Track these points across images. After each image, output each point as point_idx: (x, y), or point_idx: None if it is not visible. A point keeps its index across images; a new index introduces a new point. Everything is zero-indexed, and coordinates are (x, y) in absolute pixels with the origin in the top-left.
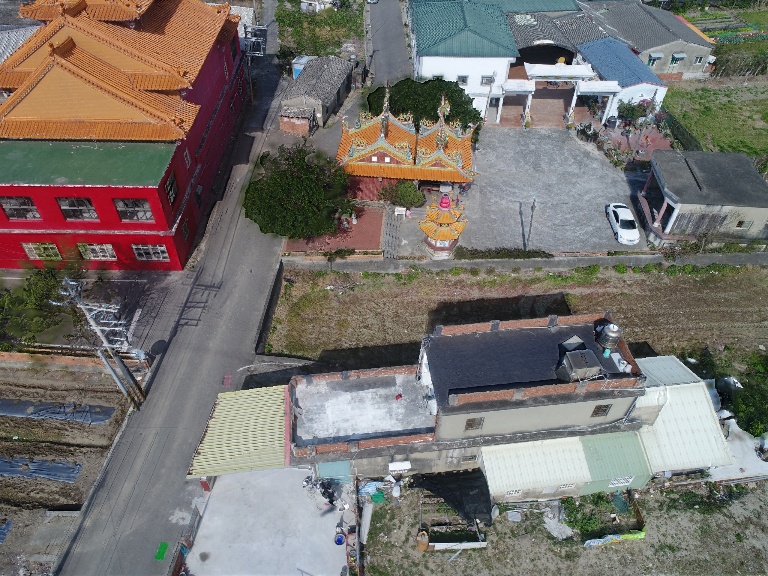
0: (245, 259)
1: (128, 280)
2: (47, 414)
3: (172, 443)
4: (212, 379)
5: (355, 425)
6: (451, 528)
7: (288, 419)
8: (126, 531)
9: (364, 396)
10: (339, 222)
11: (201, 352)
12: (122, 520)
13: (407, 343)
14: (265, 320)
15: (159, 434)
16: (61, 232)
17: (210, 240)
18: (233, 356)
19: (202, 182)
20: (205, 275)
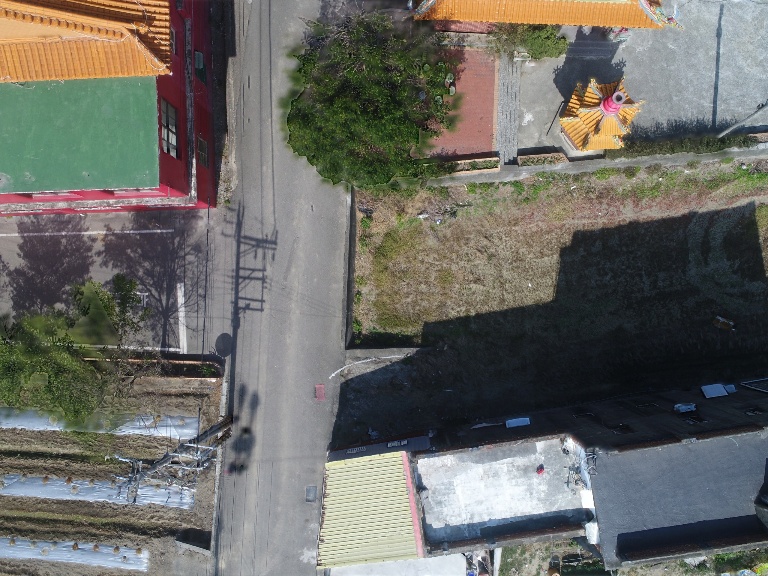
0: (299, 185)
1: (147, 230)
2: (128, 430)
3: (279, 477)
4: (302, 392)
5: (491, 509)
6: (583, 561)
7: (413, 500)
8: (262, 573)
9: (498, 469)
10: (428, 97)
11: (279, 353)
12: (255, 562)
13: (532, 305)
14: (347, 295)
15: (262, 466)
16: (32, 208)
17: (240, 149)
18: (319, 357)
19: (197, 32)
20: (250, 219)
